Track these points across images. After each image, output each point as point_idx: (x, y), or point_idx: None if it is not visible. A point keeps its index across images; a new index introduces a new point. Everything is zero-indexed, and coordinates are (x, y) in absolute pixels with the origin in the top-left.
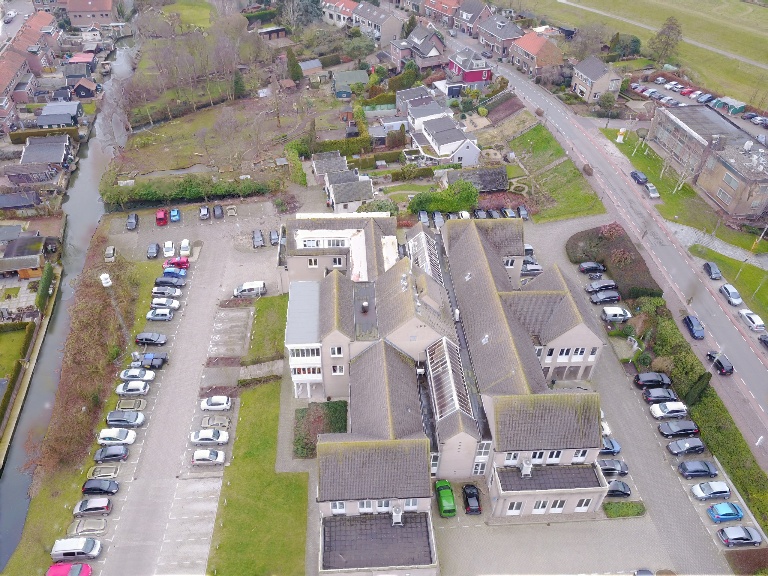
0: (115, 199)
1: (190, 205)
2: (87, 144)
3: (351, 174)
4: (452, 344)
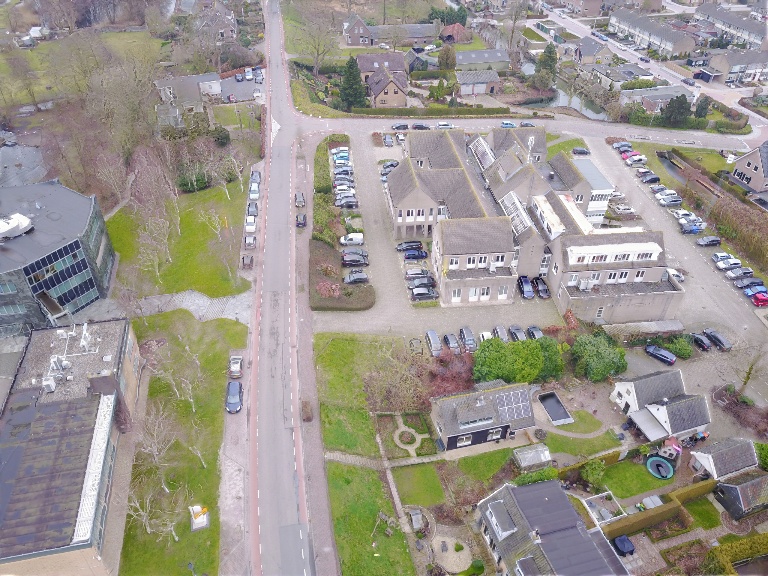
0: None
1: None
2: None
3: None
4: None
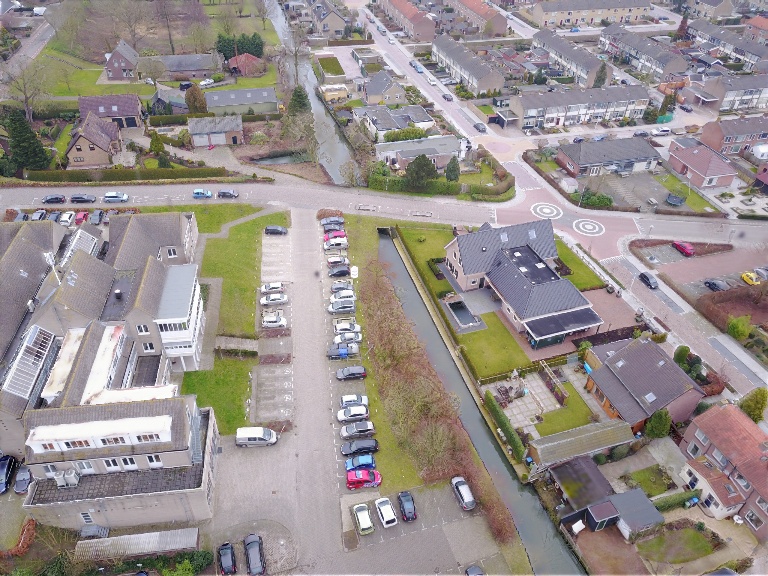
0: None
1: None
2: None
3: None
4: None
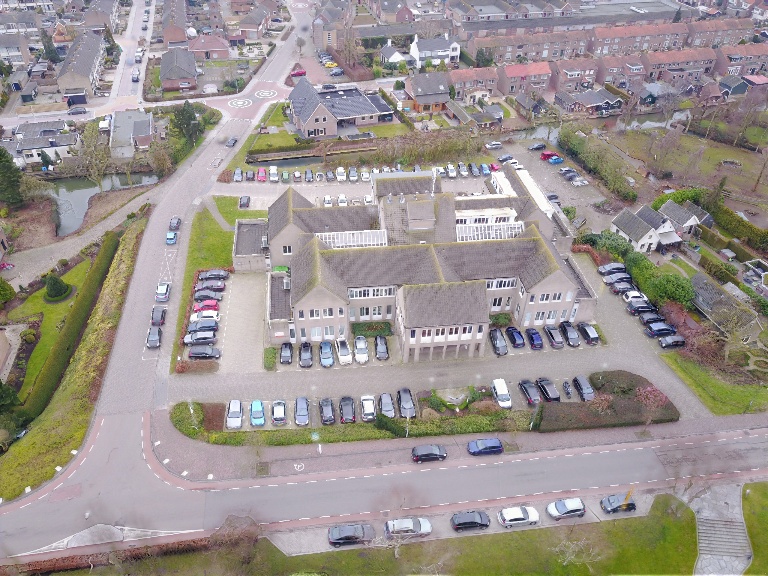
0: (560, 136)
1: (576, 166)
2: (635, 117)
3: (659, 219)
4: (385, 239)
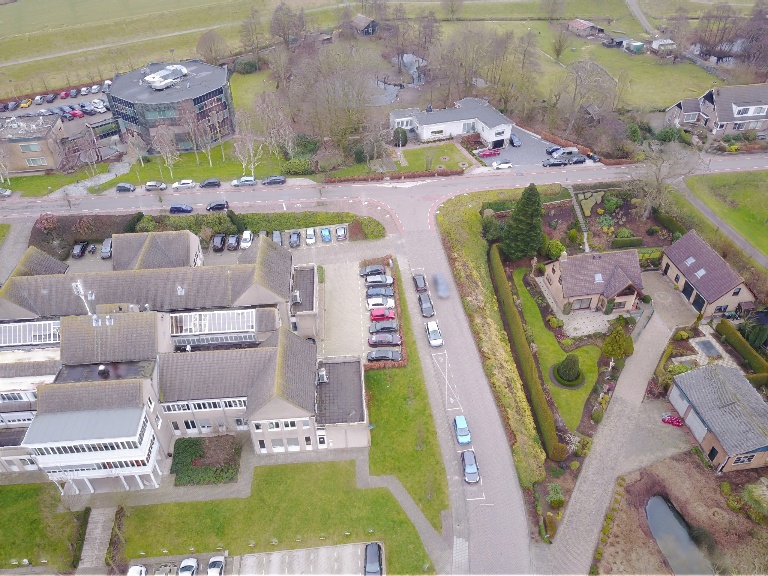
0: None
1: None
2: None
3: None
4: None
